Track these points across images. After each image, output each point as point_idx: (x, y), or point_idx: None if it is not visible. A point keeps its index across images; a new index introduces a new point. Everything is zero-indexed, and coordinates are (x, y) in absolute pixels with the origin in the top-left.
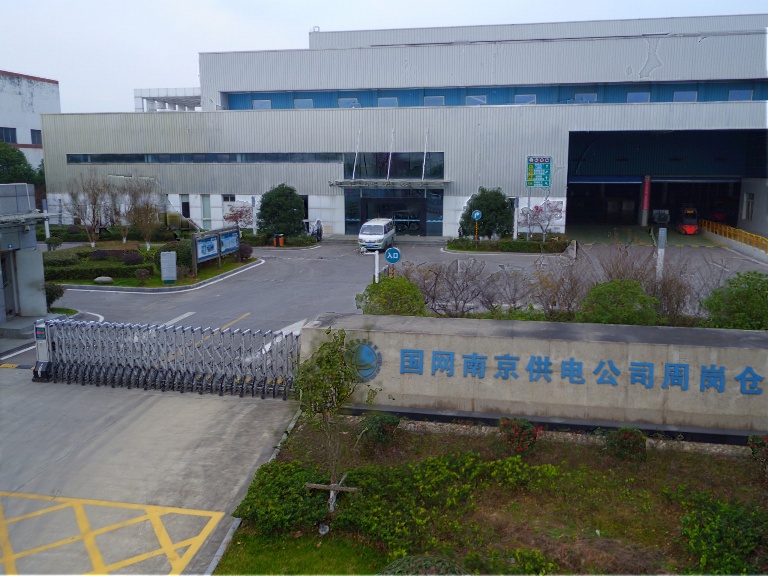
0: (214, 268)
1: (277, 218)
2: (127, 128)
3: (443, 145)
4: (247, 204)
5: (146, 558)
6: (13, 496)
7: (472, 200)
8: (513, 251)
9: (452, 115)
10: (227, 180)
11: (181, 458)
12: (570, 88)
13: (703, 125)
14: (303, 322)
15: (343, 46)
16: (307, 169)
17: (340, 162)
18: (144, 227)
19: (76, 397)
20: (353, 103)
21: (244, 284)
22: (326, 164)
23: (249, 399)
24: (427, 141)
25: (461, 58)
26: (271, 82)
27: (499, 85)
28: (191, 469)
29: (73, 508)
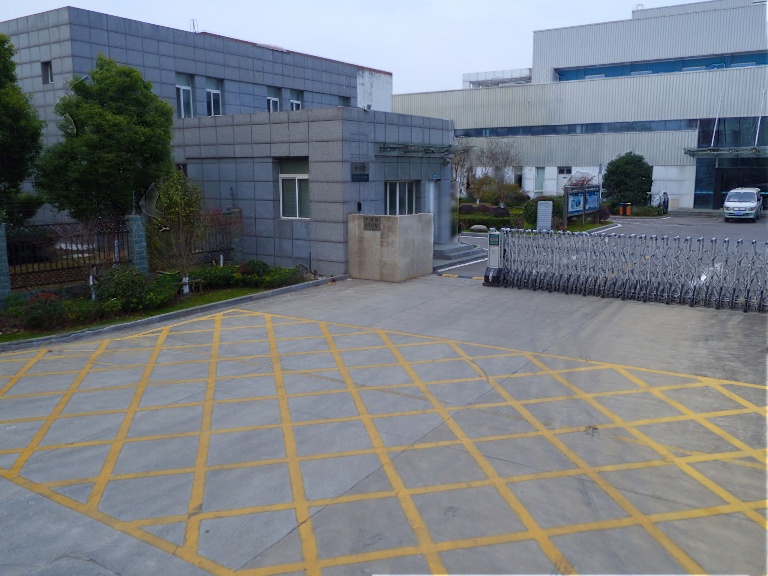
0: (575, 226)
1: (623, 187)
2: (469, 104)
3: None
4: (588, 174)
5: (738, 413)
6: (544, 356)
7: None
8: None
9: None
10: (564, 152)
11: (697, 346)
12: None
13: None
14: None
15: (694, 9)
16: (654, 138)
17: (694, 129)
18: (500, 188)
19: (536, 298)
20: (716, 64)
21: None
22: (677, 132)
23: (728, 311)
24: None
25: None
26: (608, 55)
27: None
28: (718, 355)
29: (615, 369)
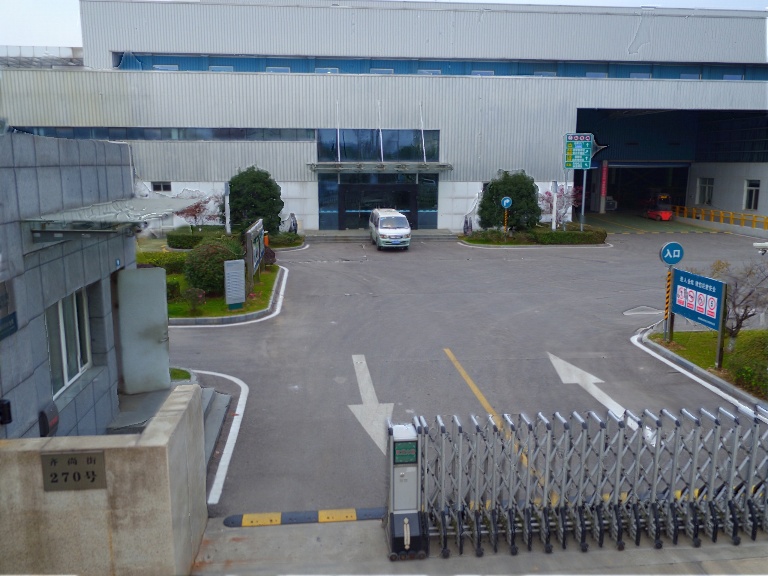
0: None
1: (253, 210)
2: (6, 90)
3: (439, 121)
4: (199, 193)
5: None
6: None
7: (493, 185)
8: (556, 243)
9: (449, 86)
10: (159, 163)
11: None
12: (529, 65)
13: (709, 105)
14: (559, 359)
15: (276, 2)
16: (269, 149)
17: (312, 140)
18: None
19: None
20: (329, 67)
21: (331, 302)
22: (294, 143)
23: None
24: (421, 116)
25: (417, 25)
26: (182, 42)
27: (458, 58)
28: None
29: None
